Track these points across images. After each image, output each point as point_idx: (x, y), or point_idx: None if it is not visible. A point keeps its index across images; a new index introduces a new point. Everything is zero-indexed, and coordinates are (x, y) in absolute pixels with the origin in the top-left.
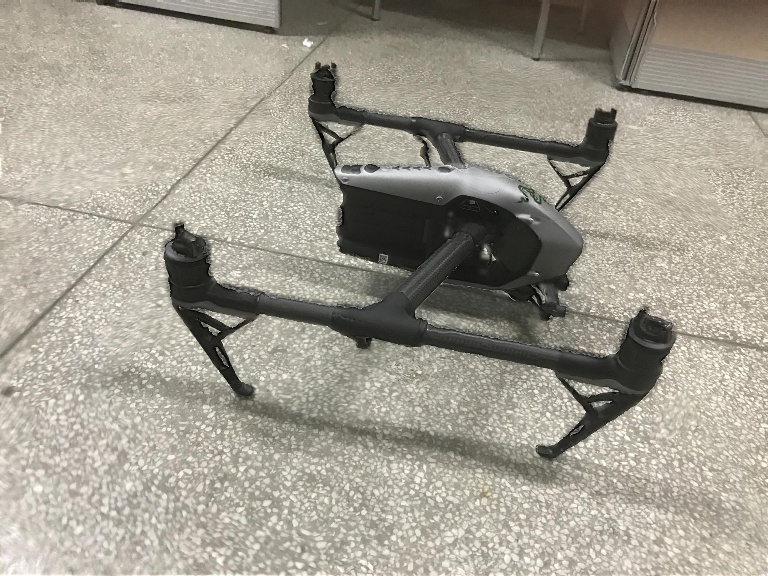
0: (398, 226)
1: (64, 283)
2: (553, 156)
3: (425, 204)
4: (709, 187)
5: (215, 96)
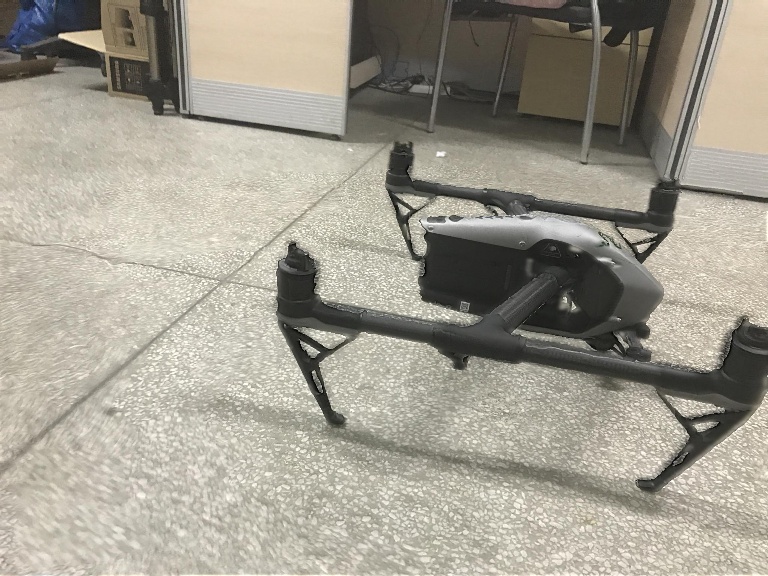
0: (480, 274)
1: (160, 325)
2: (621, 223)
3: (508, 249)
4: None
5: (289, 186)
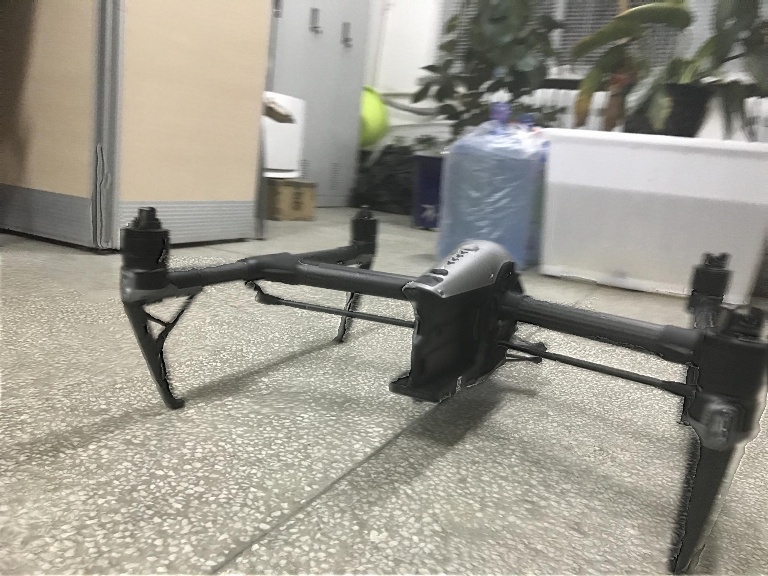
0: (454, 336)
1: None
2: (346, 261)
3: (486, 288)
4: None
5: None
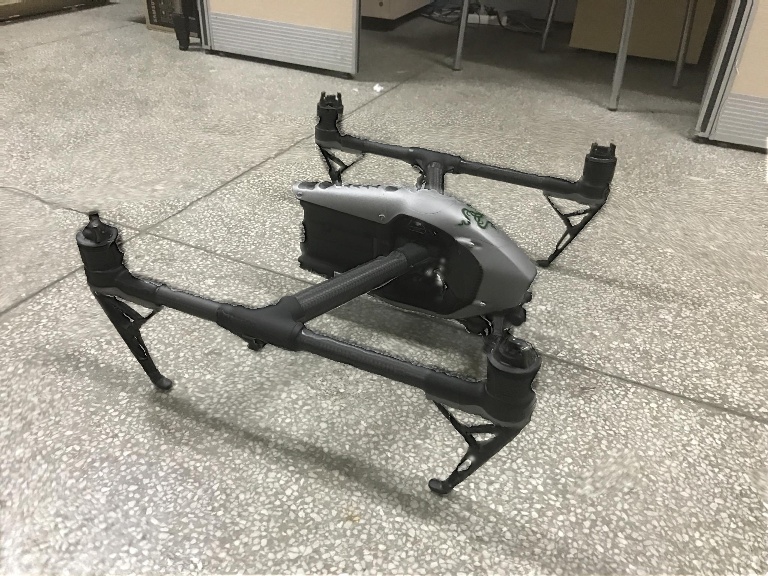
0: (352, 245)
1: (57, 275)
2: (549, 191)
3: (369, 222)
4: (763, 243)
5: (271, 131)
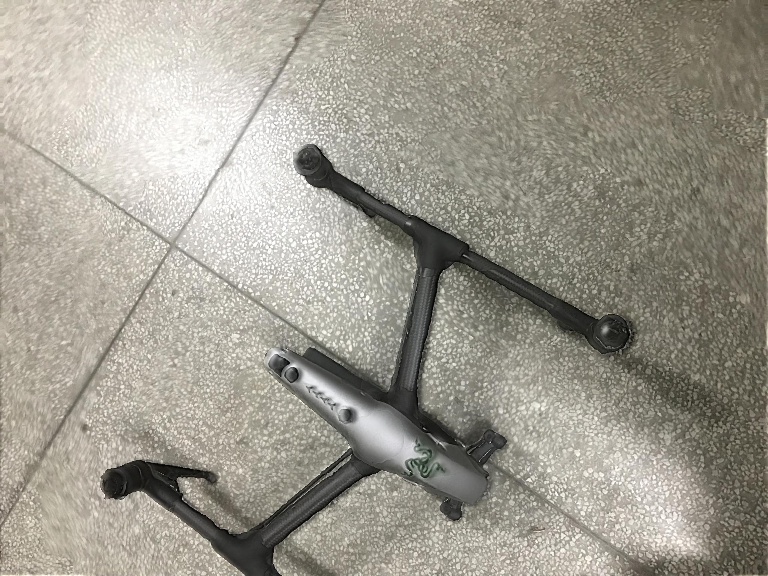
0: None
1: (118, 320)
2: (557, 319)
3: None
4: None
5: None
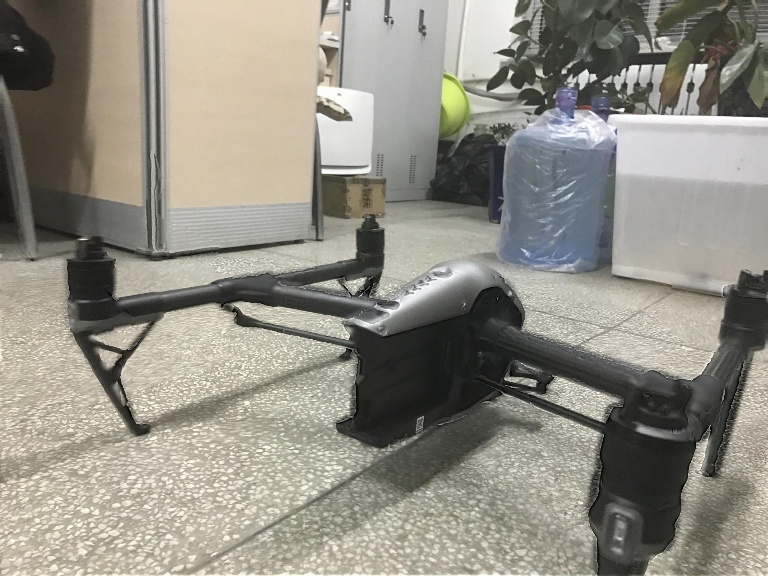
0: (417, 372)
1: None
2: (350, 276)
3: (456, 319)
4: None
5: None
